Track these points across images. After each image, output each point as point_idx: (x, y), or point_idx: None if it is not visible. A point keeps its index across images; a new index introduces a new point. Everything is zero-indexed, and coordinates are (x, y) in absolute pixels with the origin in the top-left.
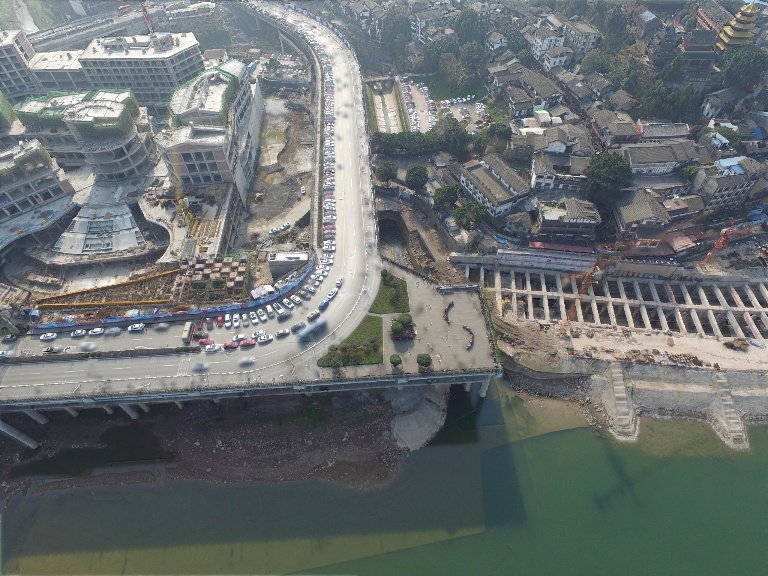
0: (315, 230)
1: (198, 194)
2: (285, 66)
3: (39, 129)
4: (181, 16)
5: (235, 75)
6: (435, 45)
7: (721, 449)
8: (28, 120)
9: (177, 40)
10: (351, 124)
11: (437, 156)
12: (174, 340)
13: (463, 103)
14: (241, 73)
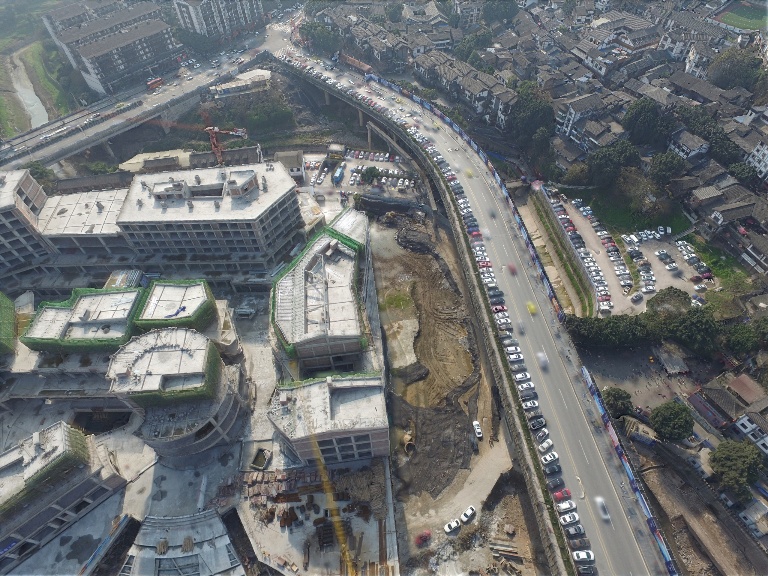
0: None
1: (337, 490)
2: (384, 173)
3: (61, 358)
4: (230, 93)
5: (360, 242)
6: (610, 155)
7: None
8: (43, 347)
9: (265, 182)
10: (531, 305)
11: (660, 350)
12: None
13: (656, 240)
14: (366, 234)
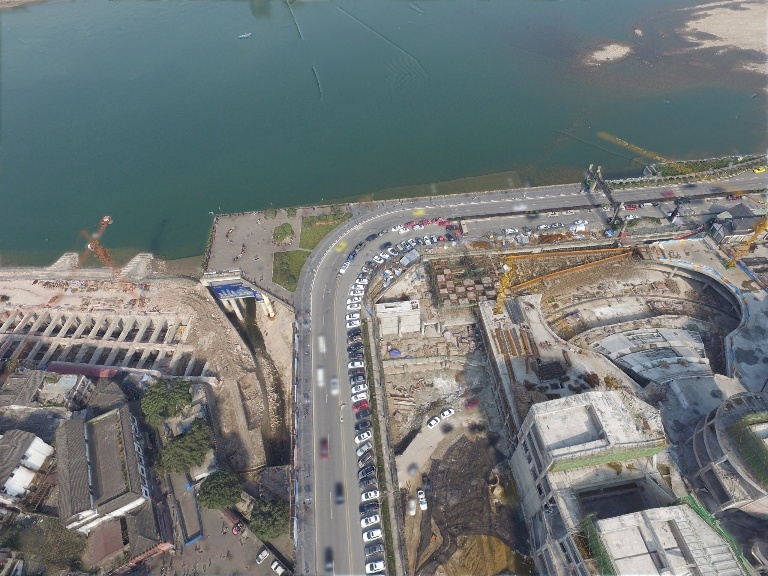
0: (373, 344)
1: None
2: None
3: None
4: None
5: None
6: None
7: (85, 253)
8: None
9: None
10: None
11: None
12: (473, 226)
13: None
14: None
